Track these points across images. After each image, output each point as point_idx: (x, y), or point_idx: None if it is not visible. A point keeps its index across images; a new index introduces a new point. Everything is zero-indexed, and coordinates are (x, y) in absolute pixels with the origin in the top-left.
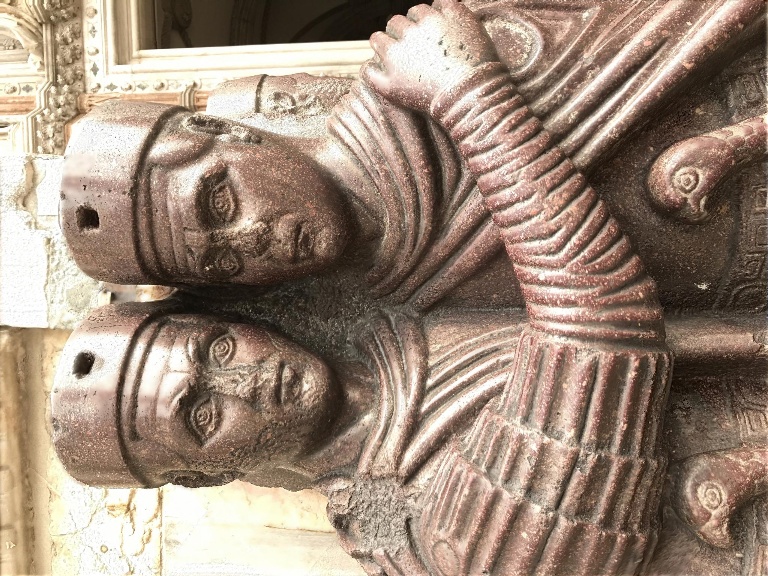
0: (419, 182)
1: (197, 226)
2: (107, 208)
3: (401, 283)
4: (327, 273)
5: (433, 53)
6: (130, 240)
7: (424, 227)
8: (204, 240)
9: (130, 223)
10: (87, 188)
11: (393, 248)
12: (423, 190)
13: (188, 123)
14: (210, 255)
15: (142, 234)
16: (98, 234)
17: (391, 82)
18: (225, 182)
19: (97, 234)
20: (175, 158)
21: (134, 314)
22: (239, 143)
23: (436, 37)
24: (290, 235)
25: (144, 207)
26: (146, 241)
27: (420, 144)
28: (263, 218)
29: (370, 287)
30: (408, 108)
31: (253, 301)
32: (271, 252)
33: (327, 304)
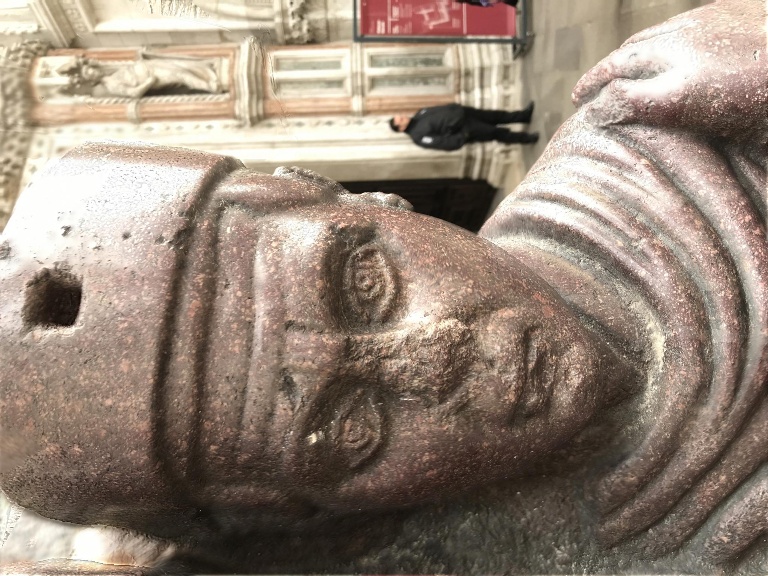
0: (743, 256)
1: (319, 318)
2: (110, 272)
3: (682, 496)
4: (497, 498)
5: (766, 24)
6: (150, 349)
7: (761, 347)
8: (331, 352)
9: (161, 306)
10: (71, 231)
11: (681, 407)
12: (755, 270)
13: (284, 169)
14: (326, 402)
15: (182, 337)
16: (70, 336)
17: (686, 78)
18: (373, 245)
19: (67, 336)
20: (274, 195)
21: (101, 571)
22: (380, 204)
23: (757, 11)
24: (515, 349)
25: (200, 274)
26: (187, 356)
27: (736, 189)
28: (458, 311)
29: (605, 515)
30: (703, 133)
31: (339, 570)
32: (469, 392)
33: (500, 568)
